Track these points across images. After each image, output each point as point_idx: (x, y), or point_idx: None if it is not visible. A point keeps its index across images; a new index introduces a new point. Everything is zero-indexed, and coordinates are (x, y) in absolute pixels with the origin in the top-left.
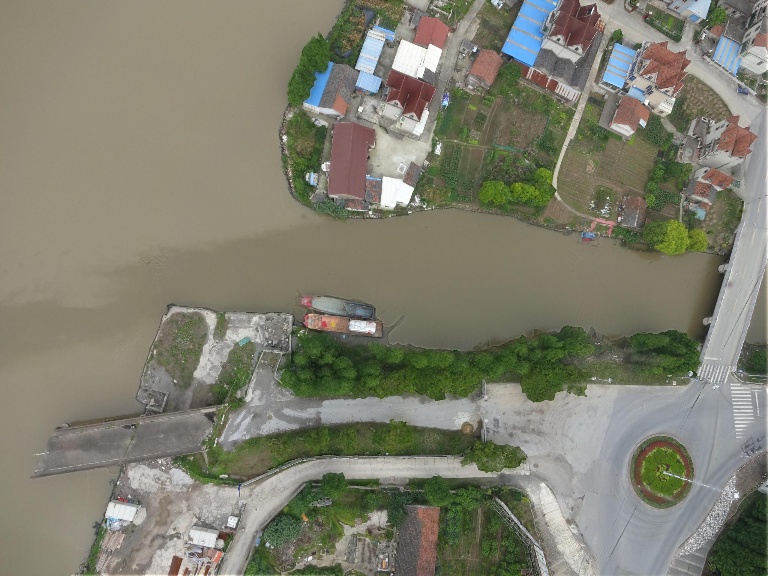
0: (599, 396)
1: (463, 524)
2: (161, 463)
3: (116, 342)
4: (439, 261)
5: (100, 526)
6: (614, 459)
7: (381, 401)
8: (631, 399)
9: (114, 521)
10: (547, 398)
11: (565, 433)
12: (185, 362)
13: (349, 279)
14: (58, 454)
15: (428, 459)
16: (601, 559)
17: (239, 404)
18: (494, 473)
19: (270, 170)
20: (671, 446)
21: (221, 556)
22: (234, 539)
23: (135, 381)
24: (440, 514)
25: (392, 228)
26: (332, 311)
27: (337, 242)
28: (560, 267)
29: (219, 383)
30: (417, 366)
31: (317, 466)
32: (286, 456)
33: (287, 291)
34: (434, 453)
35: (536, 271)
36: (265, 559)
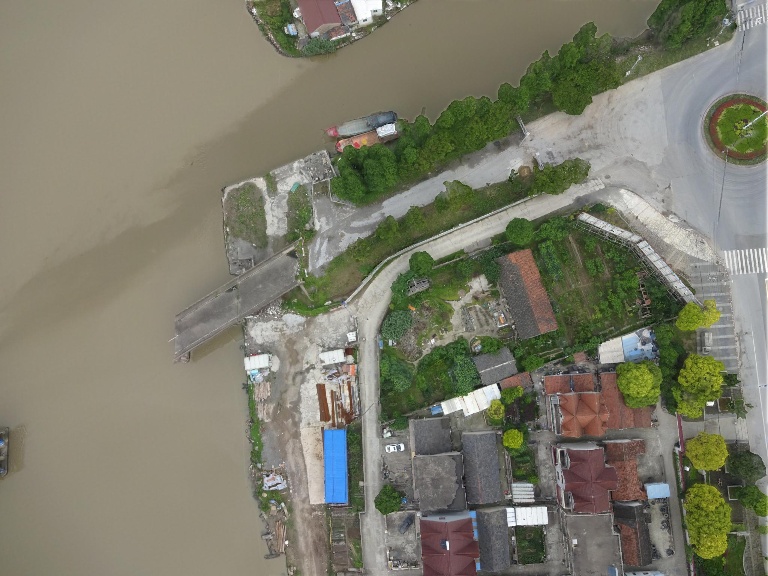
0: (642, 89)
1: (561, 257)
2: (272, 314)
3: (195, 237)
4: (437, 52)
5: (247, 385)
6: (685, 139)
7: (434, 181)
8: (677, 77)
9: (256, 375)
10: (584, 102)
11: (623, 136)
12: (254, 225)
13: (363, 102)
14: (186, 333)
15: (500, 214)
16: (715, 235)
17: (311, 234)
18: (569, 200)
19: (254, 43)
20: (740, 101)
21: (355, 368)
22: (360, 350)
23: (223, 261)
24: (534, 256)
25: (380, 41)
26: (358, 132)
27: (337, 74)
28: (554, 2)
29: (290, 231)
30: (446, 125)
31: (403, 261)
32: (371, 262)
33: (313, 134)
34: (503, 206)
35: (533, 18)
36: (393, 356)
